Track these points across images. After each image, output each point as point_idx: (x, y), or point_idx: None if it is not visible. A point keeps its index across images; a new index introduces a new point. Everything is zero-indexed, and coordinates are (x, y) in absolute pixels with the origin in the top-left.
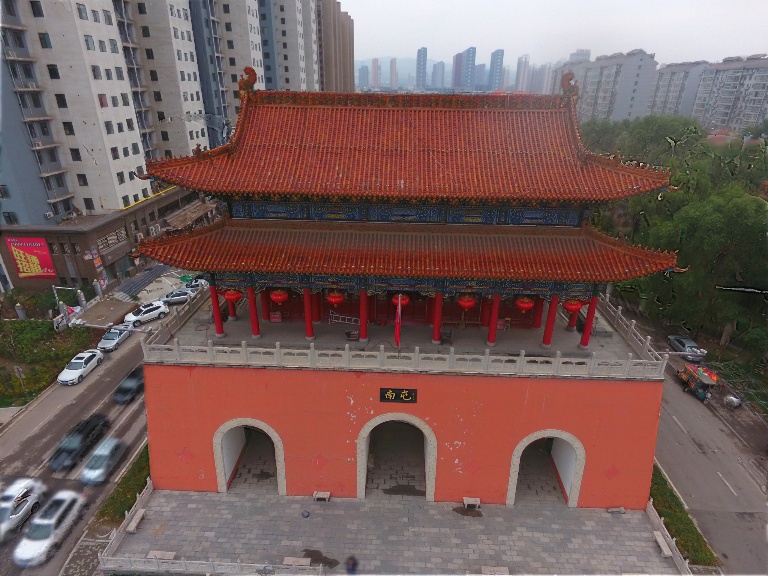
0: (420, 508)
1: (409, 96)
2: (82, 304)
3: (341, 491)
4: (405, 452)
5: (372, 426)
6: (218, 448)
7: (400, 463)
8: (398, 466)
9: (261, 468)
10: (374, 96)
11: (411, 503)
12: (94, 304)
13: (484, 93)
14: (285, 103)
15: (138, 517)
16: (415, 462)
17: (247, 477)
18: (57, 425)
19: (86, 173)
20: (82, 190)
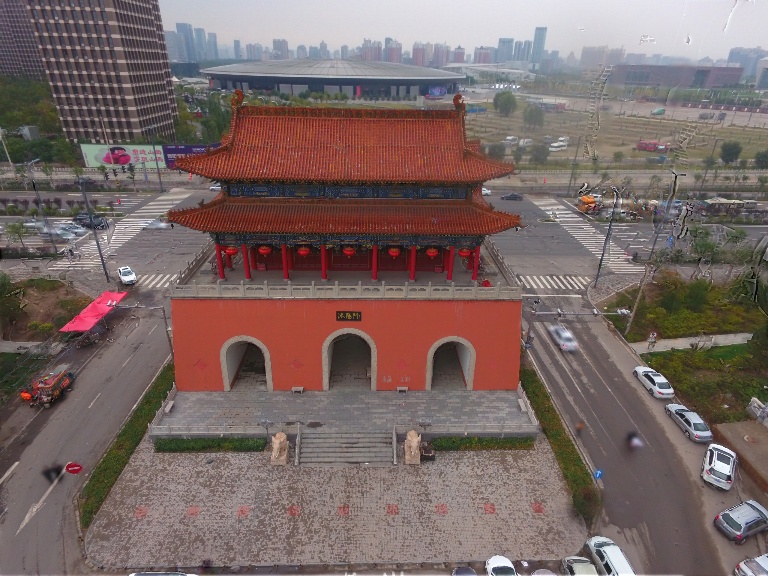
0: None
1: (348, 110)
2: None
3: None
4: None
5: None
6: None
7: None
8: None
9: None
10: (372, 111)
11: None
12: None
13: (296, 106)
14: (434, 118)
15: None
16: None
17: None
18: (593, 345)
19: None
20: None
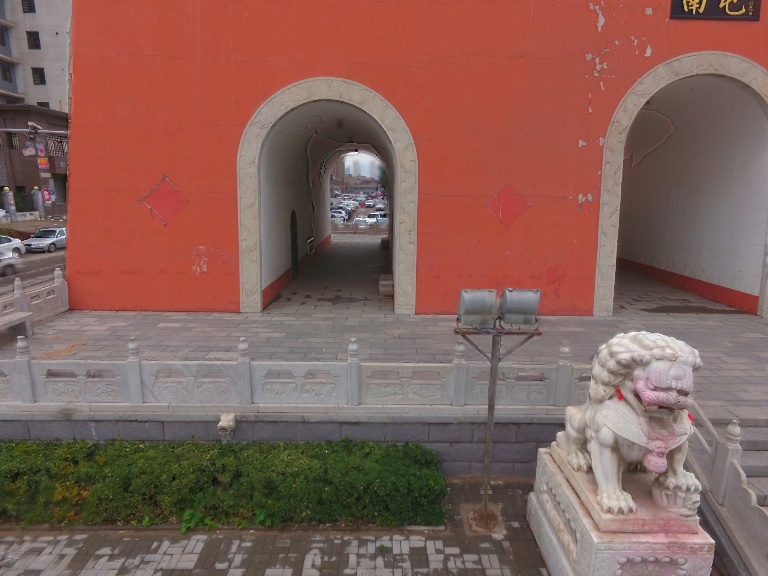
0: (766, 324)
1: None
2: (9, 209)
3: (554, 296)
4: (627, 283)
5: (645, 94)
6: (250, 174)
7: (633, 290)
8: (633, 292)
9: (334, 293)
10: None
11: (732, 319)
12: (29, 219)
13: None
14: None
15: (4, 319)
16: (663, 289)
17: (306, 300)
18: None
19: (45, 66)
20: (37, 91)
